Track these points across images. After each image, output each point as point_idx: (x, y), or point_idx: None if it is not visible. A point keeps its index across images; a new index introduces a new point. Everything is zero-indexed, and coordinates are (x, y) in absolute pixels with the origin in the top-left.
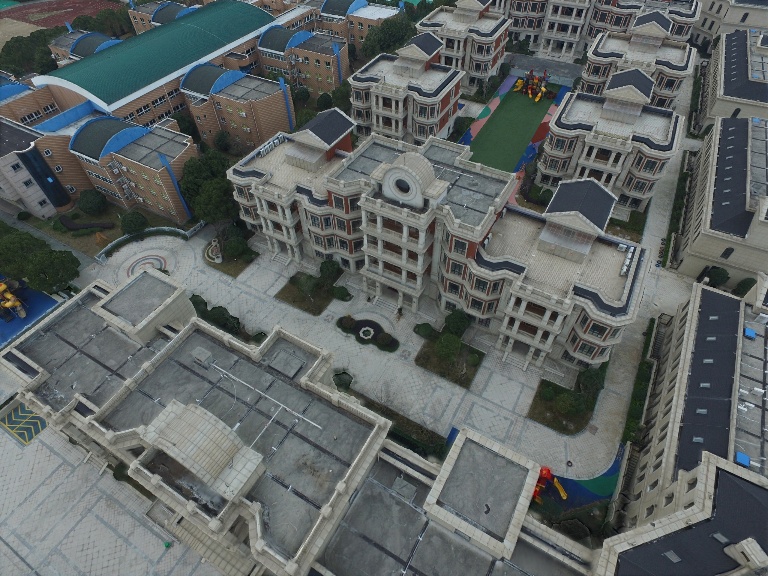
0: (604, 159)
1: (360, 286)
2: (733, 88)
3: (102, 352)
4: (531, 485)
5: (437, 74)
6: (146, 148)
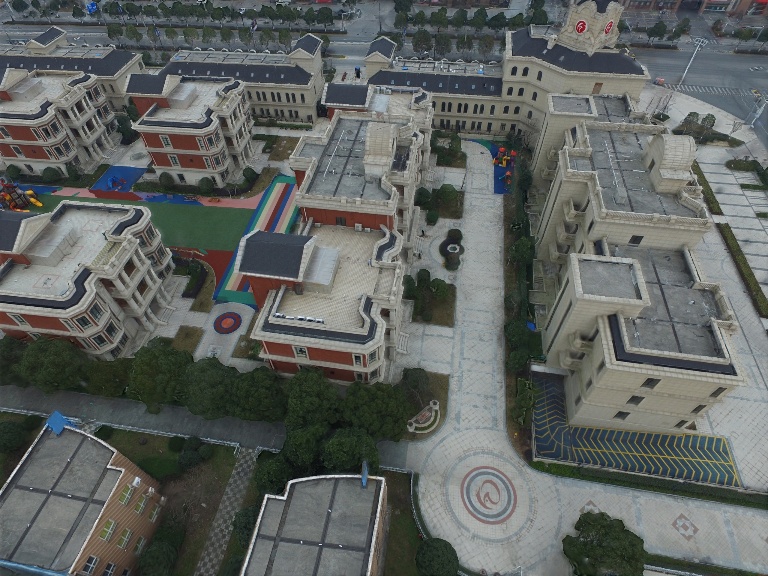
0: (235, 118)
1: (409, 266)
2: (107, 69)
3: (657, 304)
4: (559, 94)
5: (69, 222)
6: (319, 569)
